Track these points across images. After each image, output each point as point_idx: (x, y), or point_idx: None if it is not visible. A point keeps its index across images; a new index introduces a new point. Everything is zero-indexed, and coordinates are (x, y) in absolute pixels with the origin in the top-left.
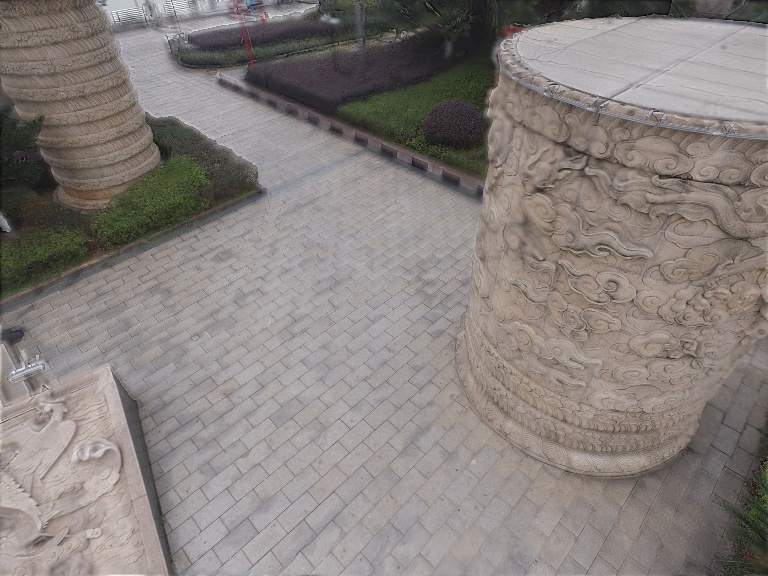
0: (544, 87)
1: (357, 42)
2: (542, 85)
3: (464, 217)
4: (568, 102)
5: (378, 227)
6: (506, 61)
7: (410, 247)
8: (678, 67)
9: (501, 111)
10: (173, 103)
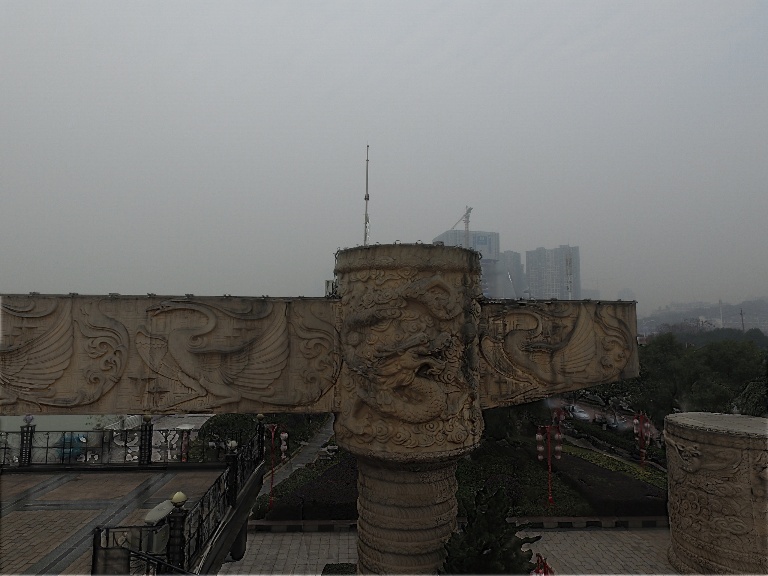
0: (755, 436)
1: (280, 467)
2: (754, 435)
3: (584, 541)
4: (766, 438)
5: (577, 567)
6: (724, 432)
7: (609, 567)
8: (747, 425)
9: (726, 449)
10: (235, 568)
